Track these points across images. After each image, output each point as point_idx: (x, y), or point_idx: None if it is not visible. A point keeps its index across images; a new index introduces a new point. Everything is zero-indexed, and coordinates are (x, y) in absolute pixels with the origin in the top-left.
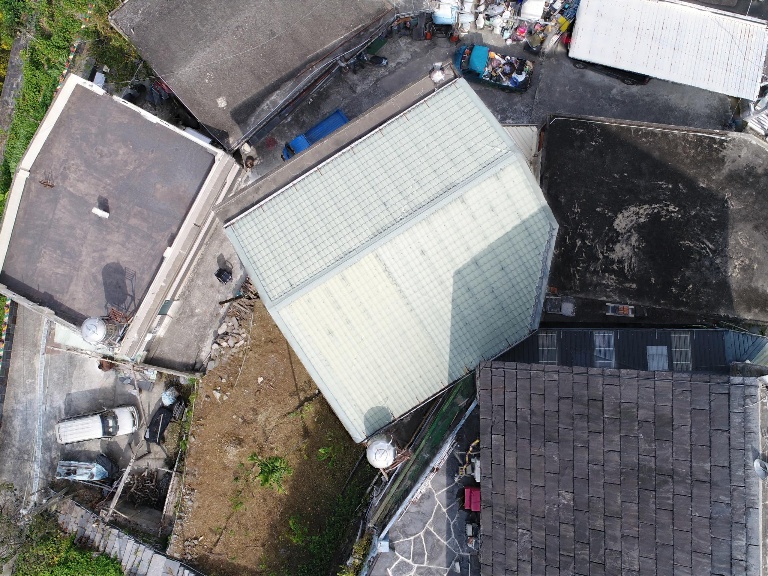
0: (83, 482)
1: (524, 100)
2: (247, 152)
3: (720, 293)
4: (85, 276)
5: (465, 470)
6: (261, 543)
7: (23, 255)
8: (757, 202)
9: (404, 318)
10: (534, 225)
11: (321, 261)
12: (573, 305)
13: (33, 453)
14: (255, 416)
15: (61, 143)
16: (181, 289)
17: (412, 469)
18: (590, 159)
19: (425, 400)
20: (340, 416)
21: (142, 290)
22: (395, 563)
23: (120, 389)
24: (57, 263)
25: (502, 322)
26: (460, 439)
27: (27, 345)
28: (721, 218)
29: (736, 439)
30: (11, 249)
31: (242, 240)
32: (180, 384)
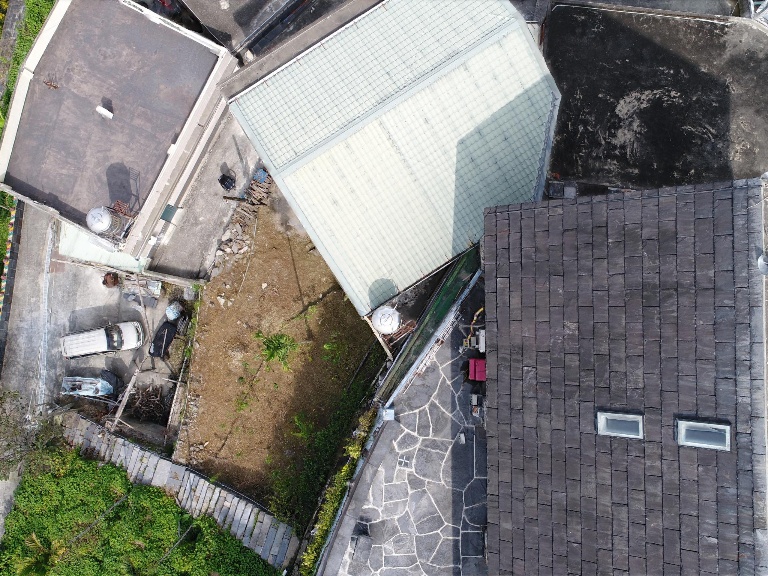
0: (88, 398)
1: (525, 7)
2: (250, 60)
3: (722, 177)
4: (89, 176)
5: (469, 342)
6: (266, 445)
7: (28, 156)
8: (758, 87)
9: (408, 188)
10: (537, 95)
11: (325, 129)
12: (576, 189)
13: (38, 370)
14: (259, 322)
15: (65, 45)
16: (185, 197)
17: (417, 344)
18: (592, 45)
19: (429, 273)
20: (345, 288)
21: (146, 190)
22: (400, 436)
23: (124, 306)
24: (61, 164)
25: (505, 194)
26: (464, 312)
27: (31, 264)
28: (722, 103)
29: (740, 241)
30: (16, 150)
31: (246, 114)
32: (184, 300)
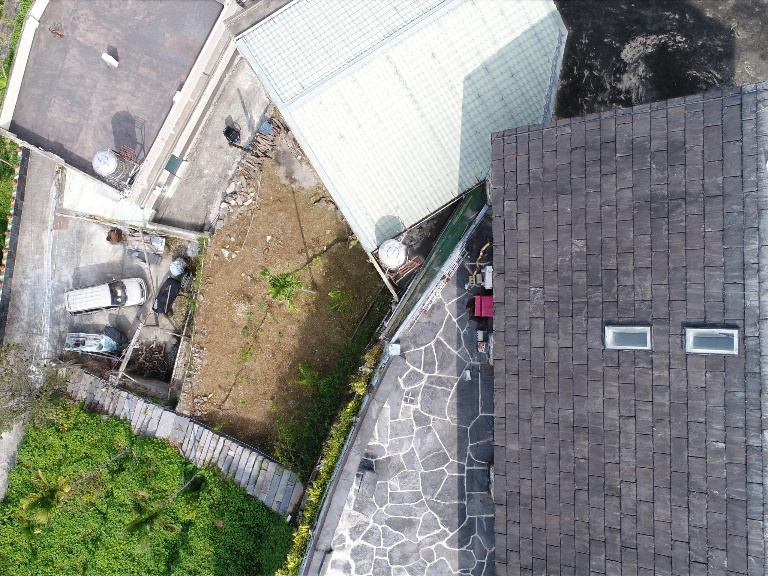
0: (92, 354)
1: None
2: None
3: None
4: (95, 125)
5: (475, 279)
6: (270, 396)
7: (33, 105)
8: (763, 32)
9: (415, 124)
10: (543, 31)
11: (332, 64)
12: None
13: (42, 327)
14: None
15: None
16: (189, 149)
17: (422, 282)
18: None
19: (435, 211)
20: (351, 224)
21: (152, 138)
22: (406, 373)
23: (128, 263)
24: (67, 112)
25: None
26: (470, 250)
27: (35, 221)
28: (727, 48)
29: (748, 146)
30: (21, 99)
31: (253, 50)
32: (188, 257)
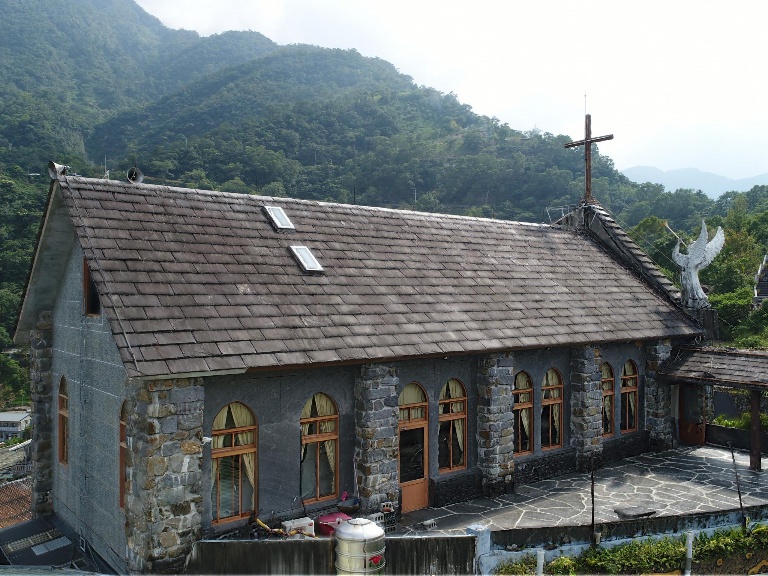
0: None
1: None
2: None
3: None
4: None
5: None
6: None
7: None
8: None
9: None
10: None
11: None
12: None
13: None
14: None
15: None
16: None
17: None
18: None
19: None
20: None
21: None
22: None
23: None
24: None
25: None
26: None
27: None
28: None
29: None
30: None
31: None
32: None
